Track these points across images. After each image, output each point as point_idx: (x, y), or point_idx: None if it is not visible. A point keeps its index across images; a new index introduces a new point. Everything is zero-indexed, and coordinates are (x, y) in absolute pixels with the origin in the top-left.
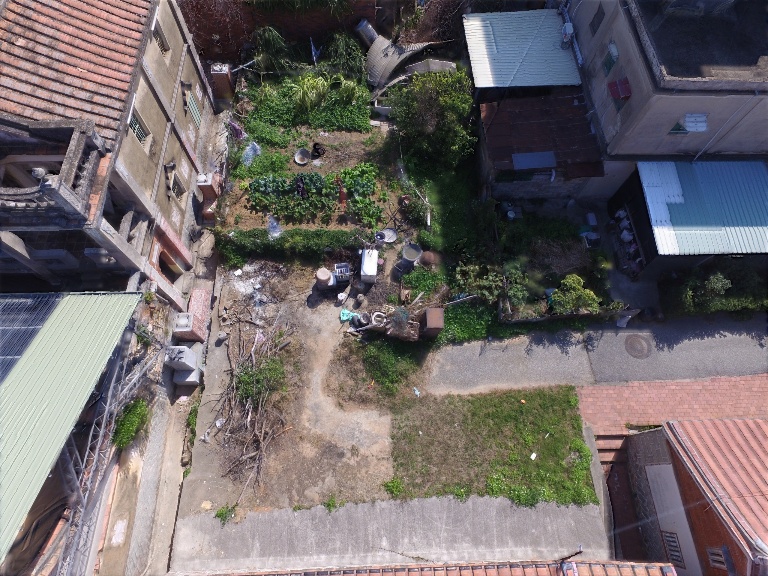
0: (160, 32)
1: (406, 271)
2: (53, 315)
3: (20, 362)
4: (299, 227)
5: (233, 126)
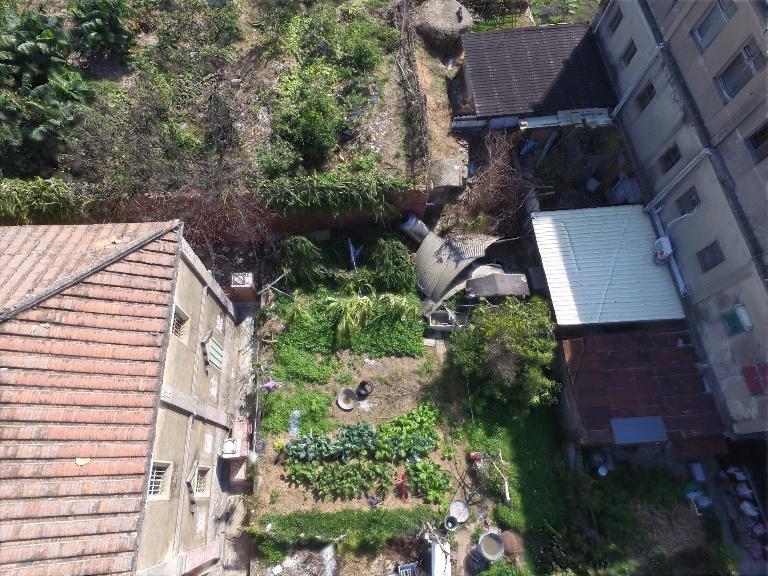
0: (177, 311)
1: (484, 564)
2: None
3: None
4: (349, 505)
5: (266, 387)
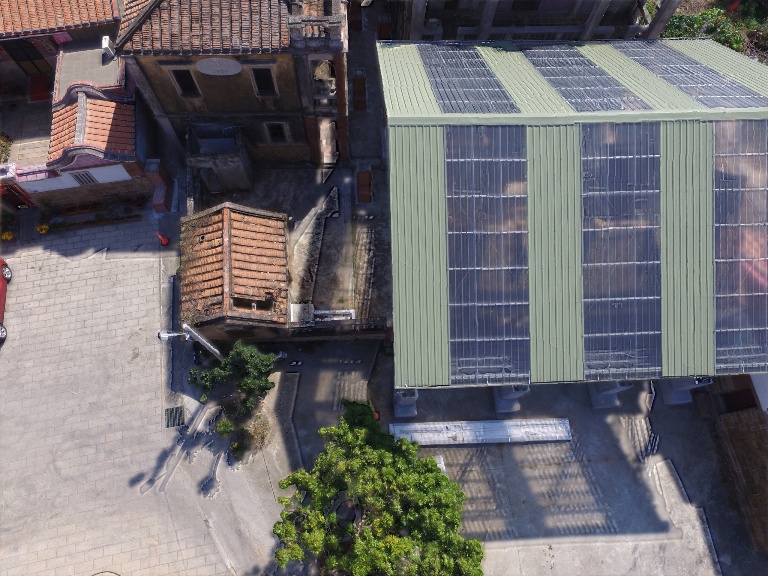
0: None
1: None
2: None
3: None
4: None
5: None
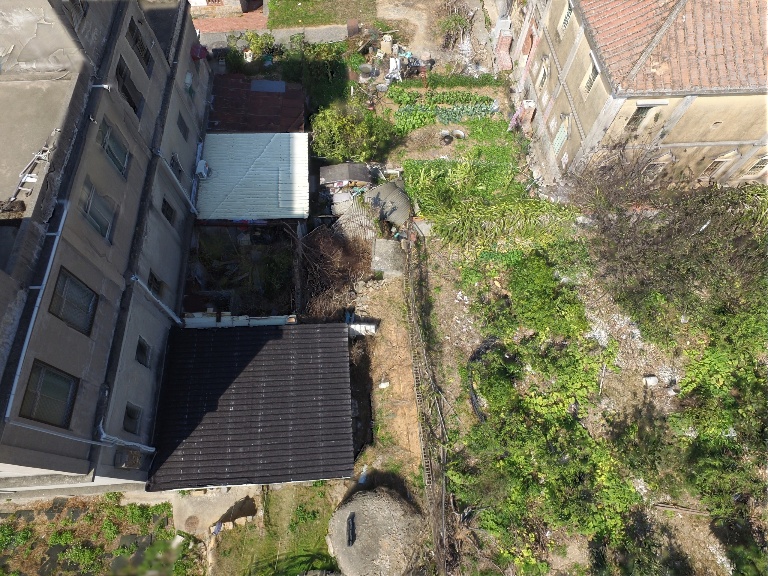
0: None
1: None
2: None
3: None
4: (449, 90)
5: None
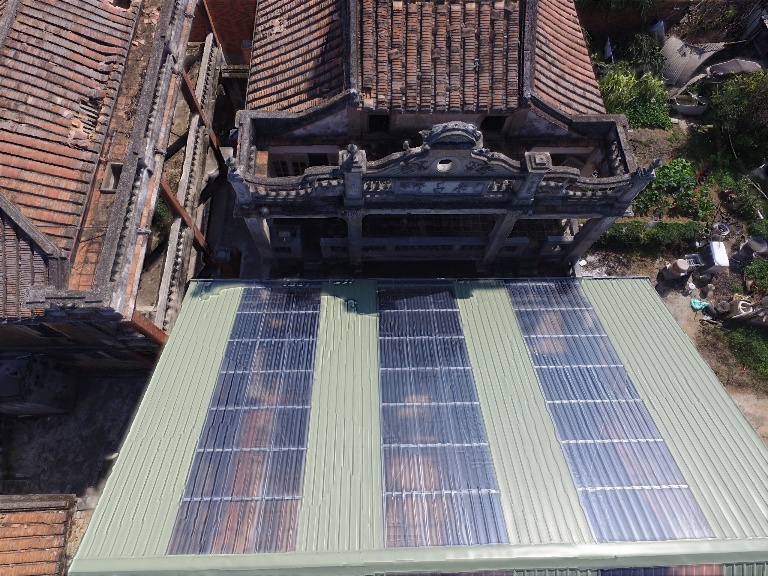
0: None
1: (746, 262)
2: (590, 298)
3: (613, 340)
4: (635, 220)
5: None
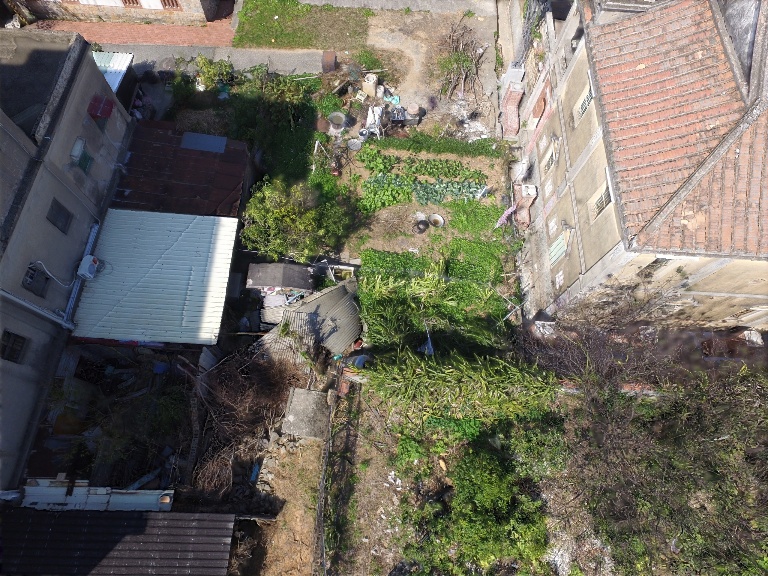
0: None
1: None
2: None
3: None
4: (435, 157)
5: None
